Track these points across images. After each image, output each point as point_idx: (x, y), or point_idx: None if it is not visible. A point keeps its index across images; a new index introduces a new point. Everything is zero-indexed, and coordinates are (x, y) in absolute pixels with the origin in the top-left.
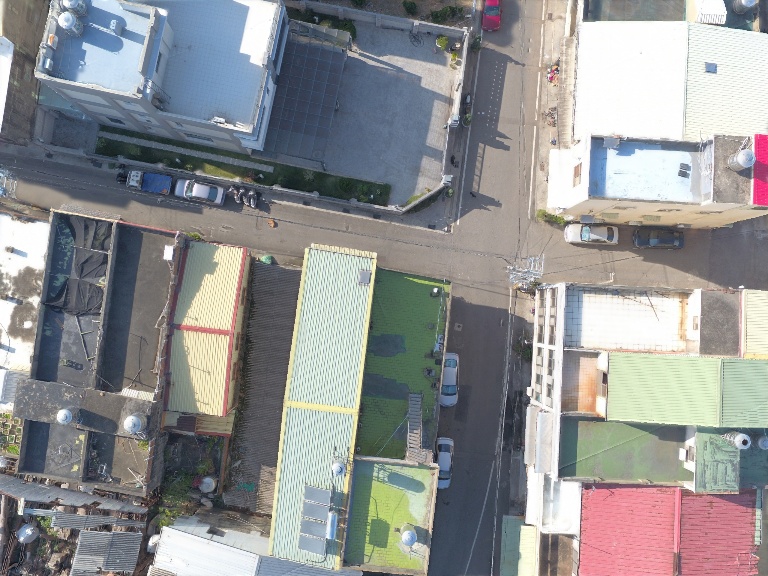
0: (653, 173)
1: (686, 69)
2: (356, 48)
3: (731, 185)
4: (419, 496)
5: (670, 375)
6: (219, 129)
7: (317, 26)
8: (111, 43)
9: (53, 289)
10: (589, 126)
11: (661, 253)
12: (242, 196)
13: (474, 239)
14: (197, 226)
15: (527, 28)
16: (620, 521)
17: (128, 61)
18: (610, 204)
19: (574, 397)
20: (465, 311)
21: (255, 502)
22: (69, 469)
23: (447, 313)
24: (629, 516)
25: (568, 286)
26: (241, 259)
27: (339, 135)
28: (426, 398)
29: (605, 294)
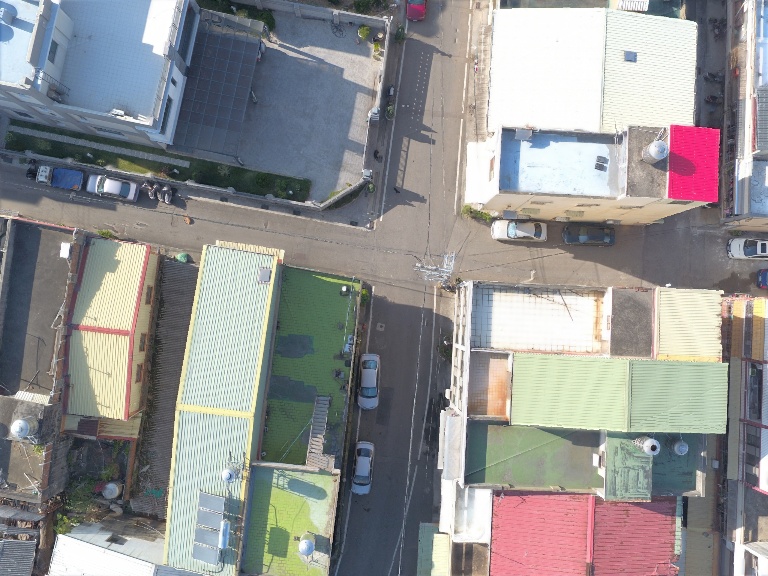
0: (568, 166)
1: (604, 58)
2: (276, 39)
3: (646, 178)
4: (320, 503)
5: (577, 377)
6: (120, 122)
7: (230, 16)
8: (1, 32)
9: None
10: (504, 118)
11: (592, 250)
12: (156, 192)
13: (397, 236)
14: (110, 223)
15: (454, 18)
16: (532, 530)
17: (19, 51)
18: (524, 199)
19: (483, 400)
20: (388, 310)
21: (163, 508)
22: None
23: (357, 312)
24: (541, 524)
25: (477, 284)
26: (144, 257)
27: (258, 129)
28: (335, 401)
29: (516, 292)
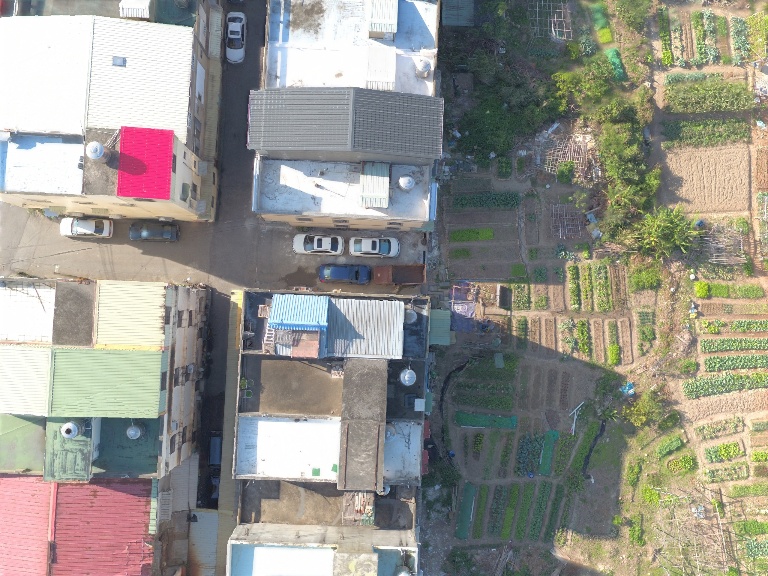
0: (53, 166)
1: (90, 63)
2: None
3: (101, 177)
4: None
5: (6, 365)
6: None
7: None
8: None
9: None
10: (3, 120)
11: (160, 246)
12: None
13: None
14: None
15: None
16: (4, 510)
17: None
18: (16, 197)
19: None
20: None
21: None
22: None
23: None
24: (12, 505)
25: None
26: None
27: None
28: None
29: None
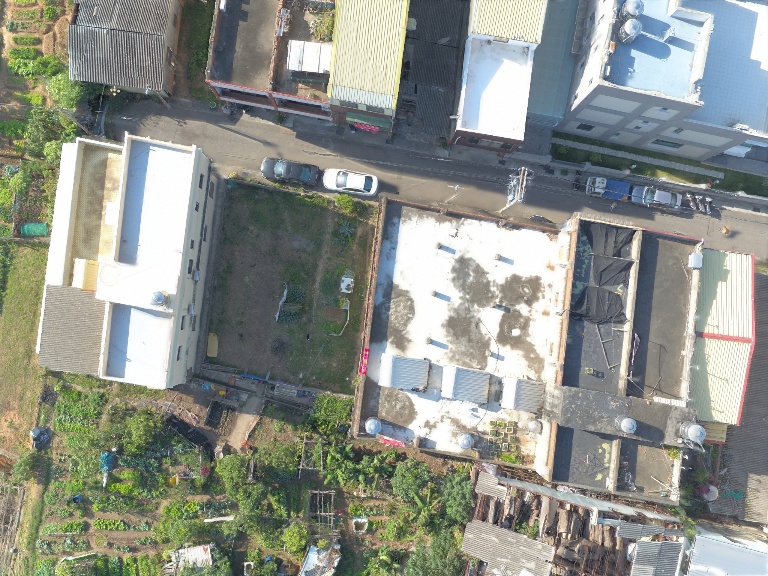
0: None
1: None
2: None
3: None
4: None
5: None
6: (734, 136)
7: None
8: (659, 50)
9: (572, 297)
10: None
11: None
12: (697, 202)
13: None
14: None
15: None
16: None
17: (676, 68)
18: None
19: None
20: None
21: (744, 510)
22: (593, 478)
23: None
24: None
25: None
26: (751, 266)
27: None
28: None
29: None
